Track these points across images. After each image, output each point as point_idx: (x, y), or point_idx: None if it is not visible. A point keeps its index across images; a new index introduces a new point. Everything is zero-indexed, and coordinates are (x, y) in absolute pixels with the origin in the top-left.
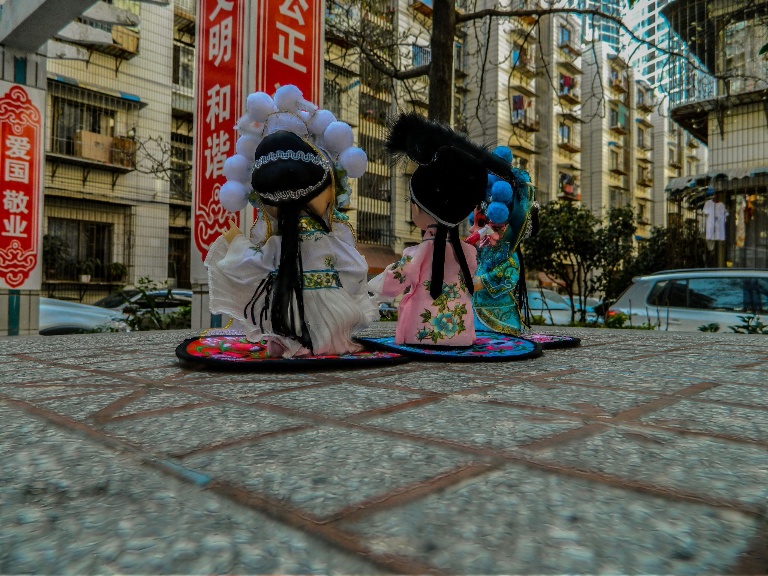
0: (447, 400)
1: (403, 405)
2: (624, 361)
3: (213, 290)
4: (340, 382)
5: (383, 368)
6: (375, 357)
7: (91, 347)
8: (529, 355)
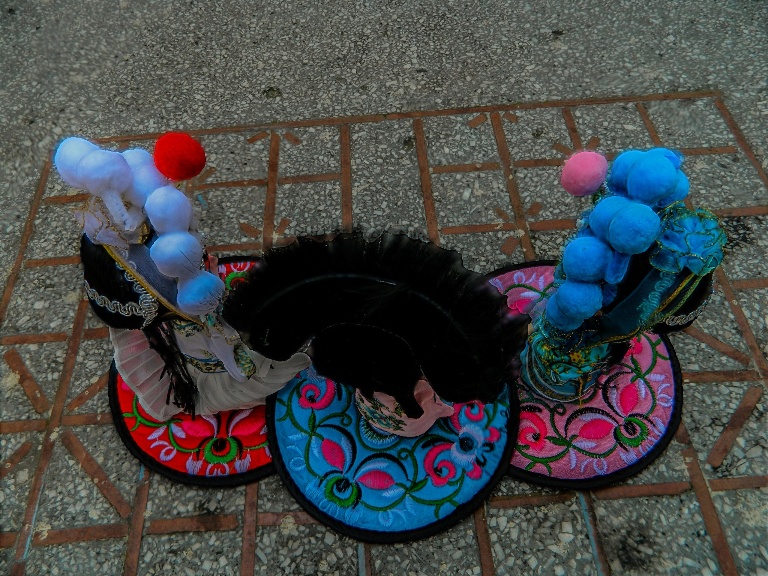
0: None
1: None
2: None
3: None
4: (124, 534)
5: (216, 491)
6: (220, 472)
7: (199, 124)
8: (400, 541)
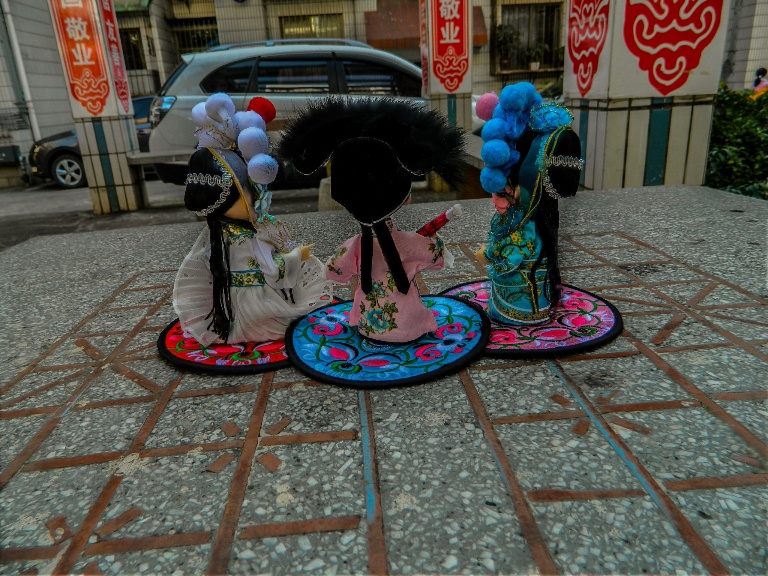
0: (116, 461)
1: (82, 458)
2: (465, 425)
3: (179, 281)
4: (154, 399)
5: (238, 377)
6: (244, 363)
7: None
8: (395, 384)
